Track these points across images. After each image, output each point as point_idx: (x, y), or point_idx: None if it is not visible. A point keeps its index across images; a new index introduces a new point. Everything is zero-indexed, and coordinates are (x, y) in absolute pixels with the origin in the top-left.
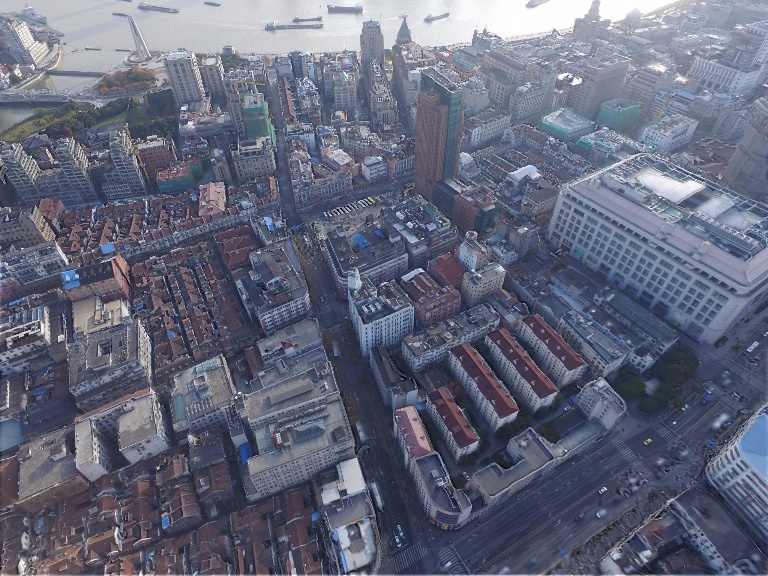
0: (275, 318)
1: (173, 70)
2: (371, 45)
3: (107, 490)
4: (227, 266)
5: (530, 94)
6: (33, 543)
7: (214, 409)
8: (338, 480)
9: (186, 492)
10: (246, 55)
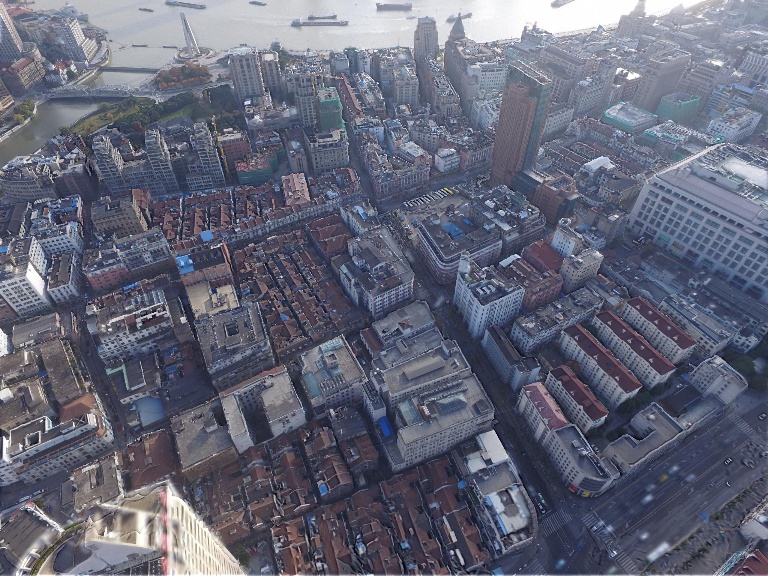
0: (384, 301)
1: (238, 65)
2: (426, 41)
3: (257, 461)
4: (325, 253)
5: (591, 88)
6: (197, 509)
7: (347, 385)
8: (481, 450)
9: (337, 462)
10: (294, 51)
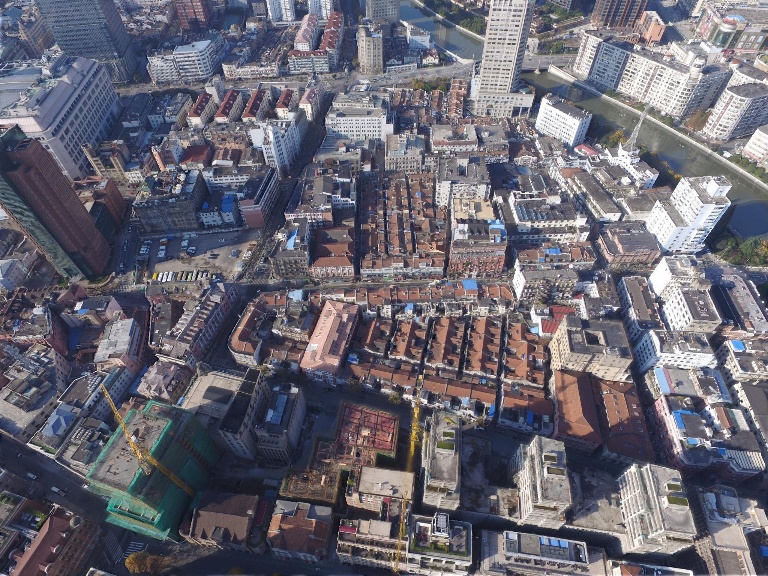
0: None
1: None
2: None
3: None
4: None
5: None
6: None
7: None
8: None
9: None
10: None
